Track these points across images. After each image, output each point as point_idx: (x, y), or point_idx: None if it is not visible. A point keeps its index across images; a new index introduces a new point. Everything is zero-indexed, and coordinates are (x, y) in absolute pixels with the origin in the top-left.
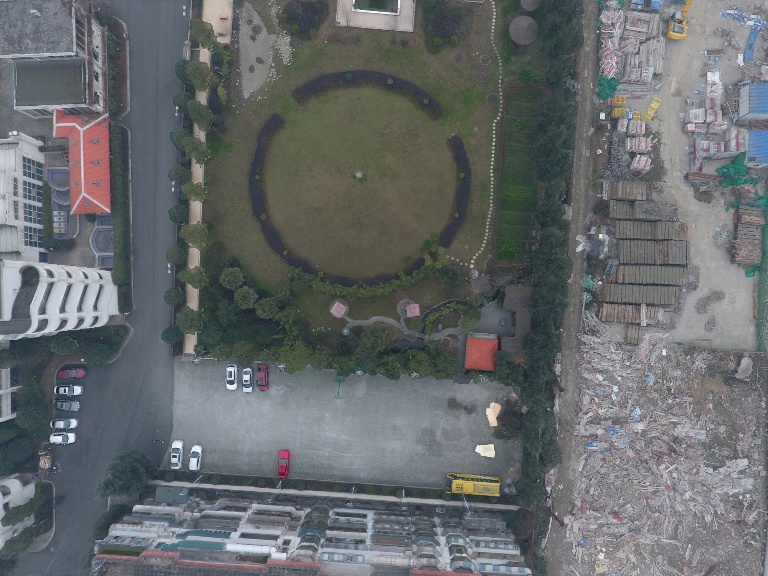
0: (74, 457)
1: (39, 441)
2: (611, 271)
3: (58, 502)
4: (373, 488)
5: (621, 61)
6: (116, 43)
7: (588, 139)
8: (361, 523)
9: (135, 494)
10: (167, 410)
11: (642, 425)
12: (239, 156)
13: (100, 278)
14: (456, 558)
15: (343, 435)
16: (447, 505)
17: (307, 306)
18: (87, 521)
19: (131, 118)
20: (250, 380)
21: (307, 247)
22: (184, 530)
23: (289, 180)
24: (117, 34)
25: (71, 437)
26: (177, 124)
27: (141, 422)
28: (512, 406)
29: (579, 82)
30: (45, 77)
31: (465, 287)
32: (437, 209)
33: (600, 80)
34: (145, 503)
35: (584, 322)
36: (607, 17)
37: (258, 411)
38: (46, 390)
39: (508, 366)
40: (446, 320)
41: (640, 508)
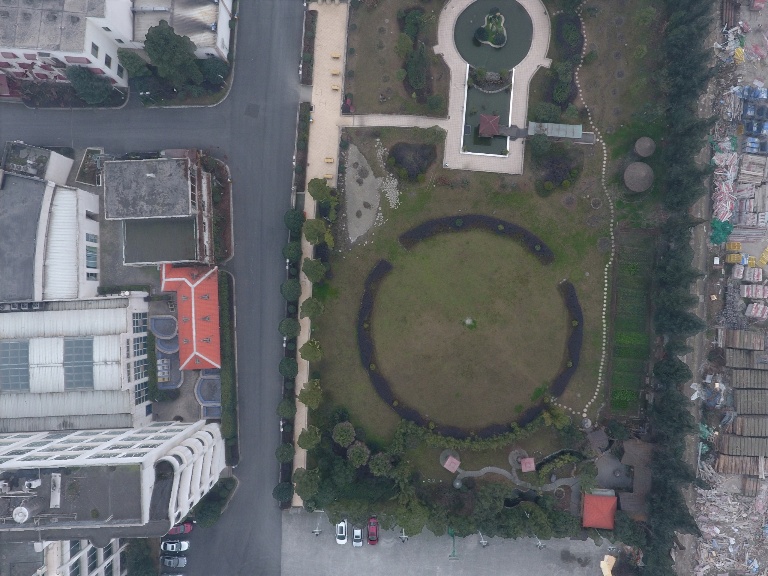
0: None
1: None
2: (728, 422)
3: None
4: None
5: (735, 205)
6: (220, 187)
7: (702, 284)
8: None
9: None
10: (275, 564)
11: None
12: (346, 302)
13: (212, 438)
14: None
15: None
16: None
17: (417, 457)
18: None
19: (235, 263)
20: (361, 535)
21: (416, 396)
22: None
23: (397, 327)
24: (221, 178)
25: None
26: (282, 270)
27: None
28: (627, 559)
29: None
30: (155, 232)
31: (582, 442)
32: (548, 356)
33: (714, 223)
34: None
35: (700, 473)
36: (720, 159)
37: (368, 564)
38: (152, 544)
39: None
40: (559, 470)
41: None
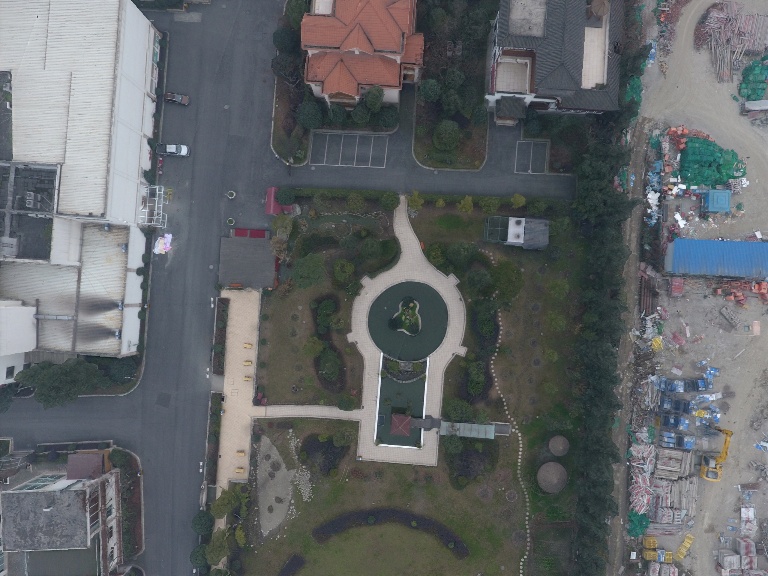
0: None
1: None
2: None
3: None
4: None
5: (652, 498)
6: None
7: None
8: None
9: None
10: None
11: None
12: None
13: None
14: None
15: None
16: None
17: None
18: None
19: (146, 558)
20: None
21: None
22: None
23: None
24: (131, 472)
25: None
26: None
27: None
28: None
29: (609, 518)
30: None
31: None
32: None
33: (630, 516)
34: None
35: None
36: (637, 450)
37: None
38: None
39: None
40: None
41: None
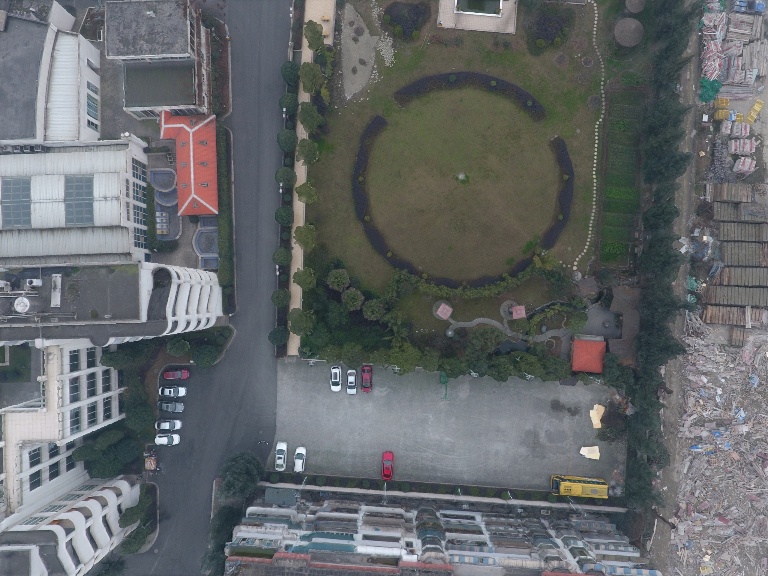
0: (178, 458)
1: (145, 442)
2: (716, 273)
3: (162, 503)
4: (478, 490)
5: (724, 63)
6: (218, 44)
7: (690, 141)
8: (474, 525)
9: (247, 496)
10: (270, 411)
11: (747, 427)
12: (341, 157)
13: (209, 279)
14: (583, 560)
15: (447, 437)
16: (554, 507)
17: (410, 308)
18: (191, 522)
19: (233, 119)
20: (355, 382)
21: (410, 249)
22: (304, 532)
23: (391, 182)
24: (219, 35)
25: (176, 438)
26: (279, 125)
27: (245, 423)
28: (616, 408)
29: (681, 84)
30: (154, 78)
31: (572, 289)
32: (540, 211)
33: (702, 82)
34: (256, 505)
35: (688, 324)
36: (709, 19)
37: (361, 413)
38: (150, 391)
39: (617, 368)
40: (549, 322)
41: (745, 510)
